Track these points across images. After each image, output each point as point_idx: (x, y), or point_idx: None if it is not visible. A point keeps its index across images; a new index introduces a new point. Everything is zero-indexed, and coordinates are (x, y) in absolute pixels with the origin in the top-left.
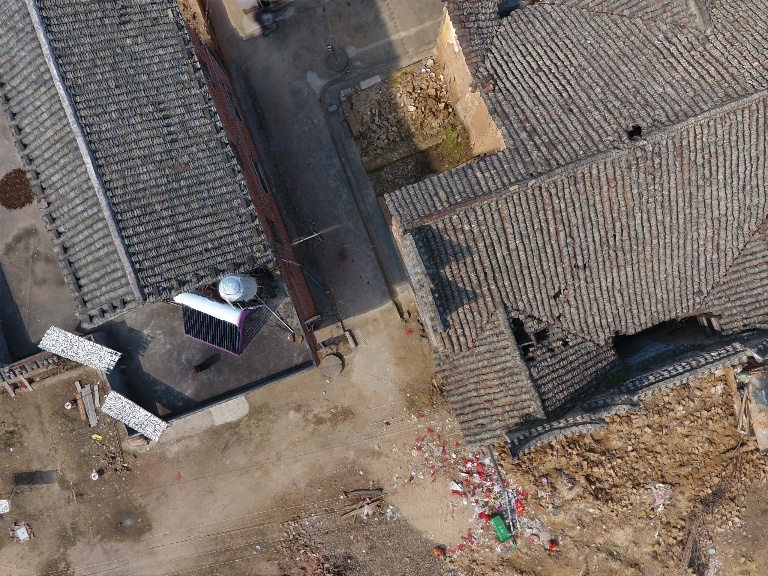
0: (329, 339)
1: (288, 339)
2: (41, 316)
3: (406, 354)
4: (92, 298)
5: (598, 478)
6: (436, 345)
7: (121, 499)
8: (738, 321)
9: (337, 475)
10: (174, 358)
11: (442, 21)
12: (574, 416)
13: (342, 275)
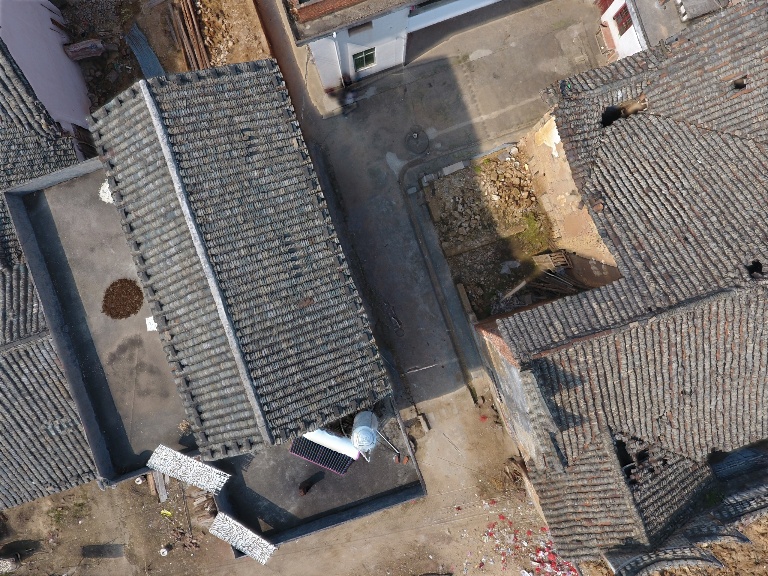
0: None
1: (393, 459)
2: (144, 428)
3: (479, 439)
4: (214, 433)
5: (671, 573)
6: (531, 456)
7: (189, 575)
8: None
9: (406, 558)
10: (277, 474)
11: (539, 122)
12: (679, 545)
13: (417, 358)
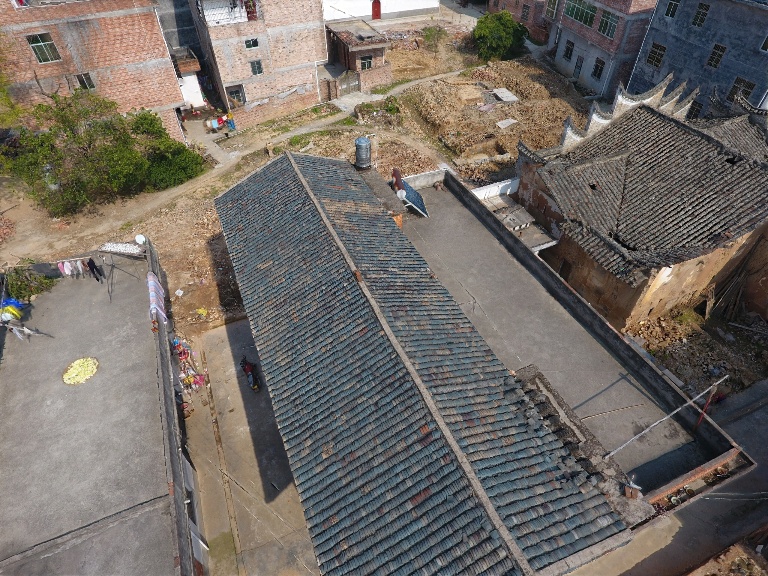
0: None
1: None
2: None
3: None
4: None
5: None
6: None
7: None
8: (765, 148)
9: None
10: None
11: (642, 294)
12: None
13: None
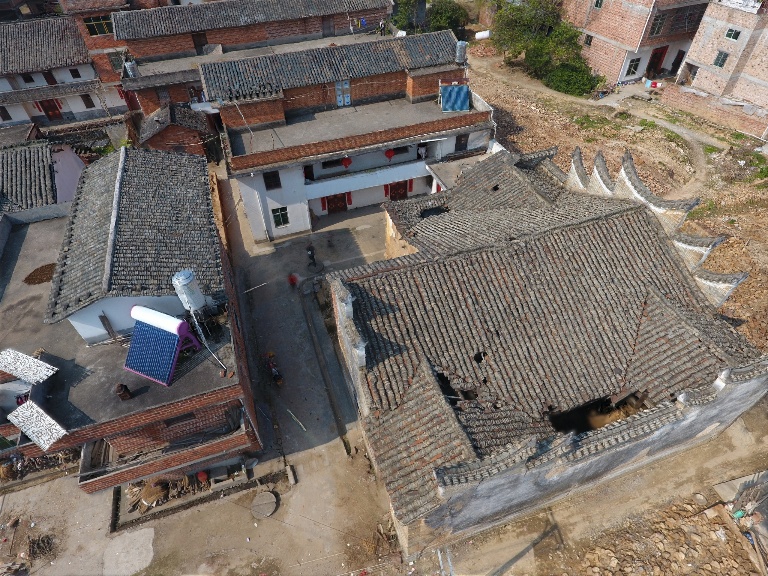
0: (267, 477)
1: (219, 374)
2: None
3: (350, 494)
4: (64, 300)
5: None
6: None
7: None
8: (664, 391)
9: None
10: (103, 389)
11: (386, 226)
12: None
13: (293, 412)
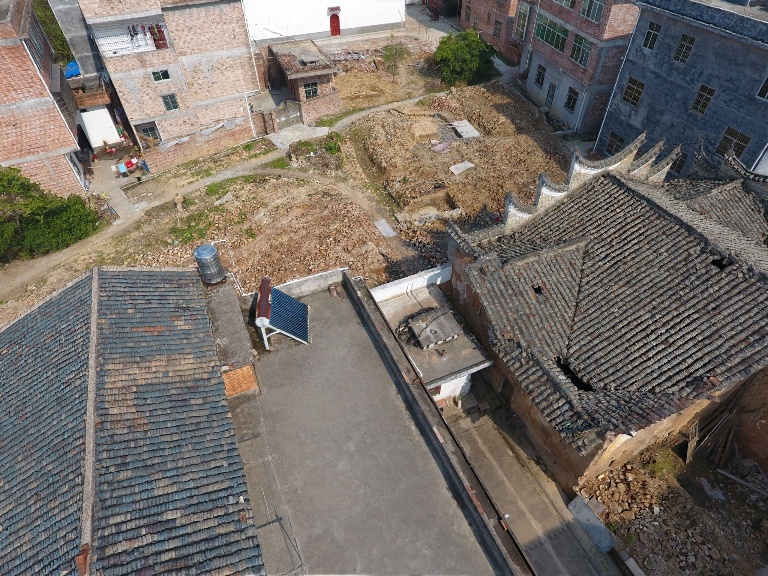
0: None
1: None
2: None
3: None
4: None
5: None
6: None
7: None
8: (763, 225)
9: None
10: None
11: None
12: None
13: None
